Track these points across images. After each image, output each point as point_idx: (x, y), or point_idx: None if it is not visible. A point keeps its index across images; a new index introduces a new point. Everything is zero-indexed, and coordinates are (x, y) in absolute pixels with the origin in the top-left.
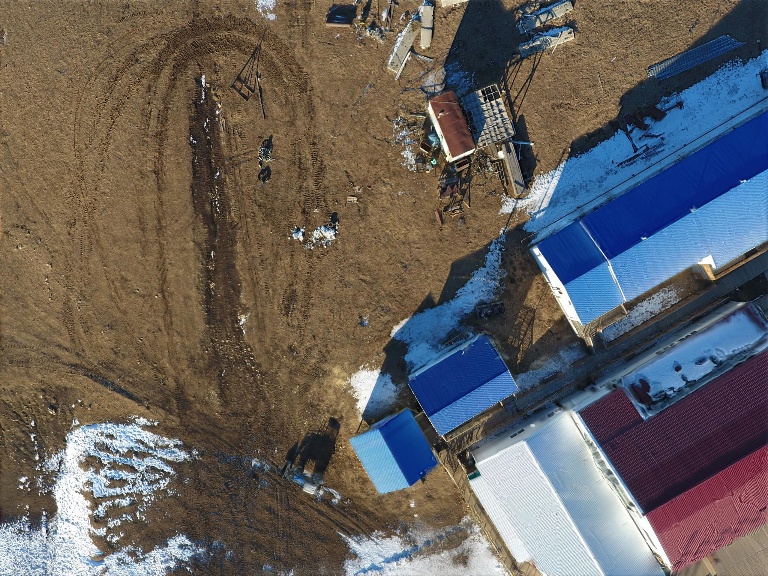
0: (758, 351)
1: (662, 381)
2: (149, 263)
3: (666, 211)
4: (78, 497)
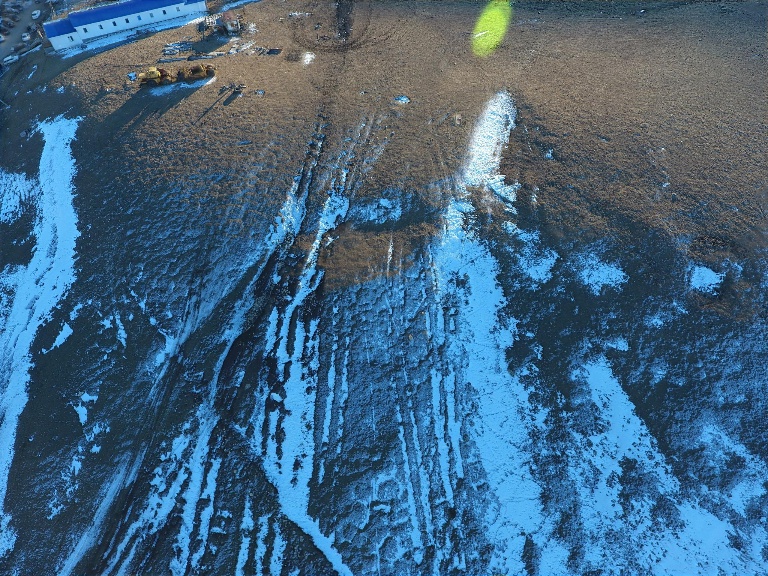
0: None
1: None
2: None
3: None
4: None
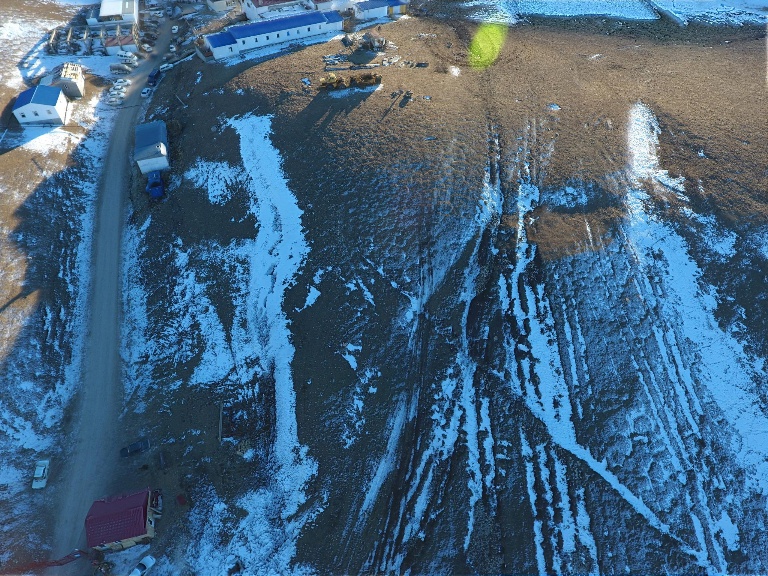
0: (269, 7)
1: (301, 8)
2: (493, 36)
3: (298, 18)
4: (509, 14)
